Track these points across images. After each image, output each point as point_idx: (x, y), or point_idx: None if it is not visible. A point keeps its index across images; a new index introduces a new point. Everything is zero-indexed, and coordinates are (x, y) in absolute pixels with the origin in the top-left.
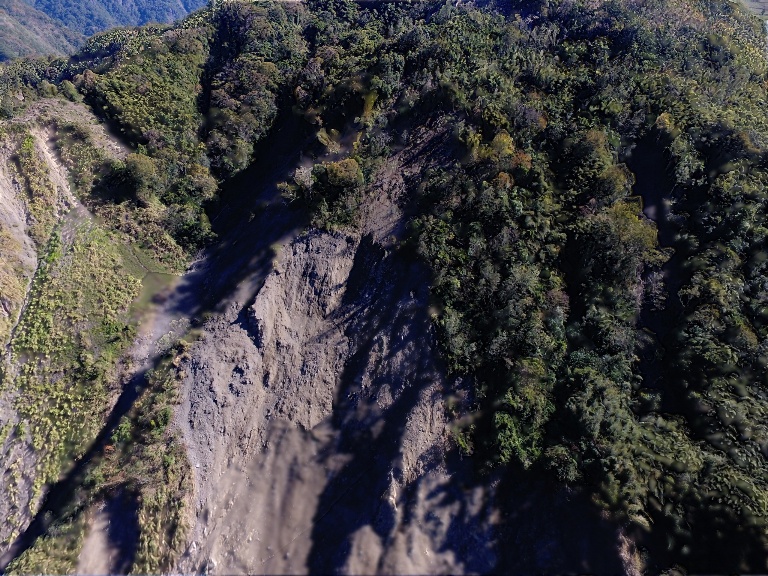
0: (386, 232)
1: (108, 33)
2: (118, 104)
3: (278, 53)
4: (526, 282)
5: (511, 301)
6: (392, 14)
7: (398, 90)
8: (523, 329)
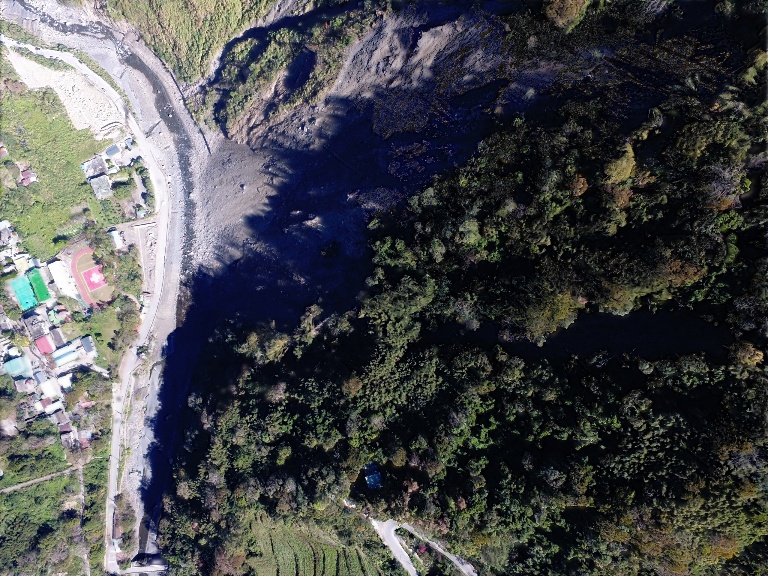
0: (513, 96)
1: None
2: None
3: None
4: None
5: (449, 227)
6: None
7: None
8: None
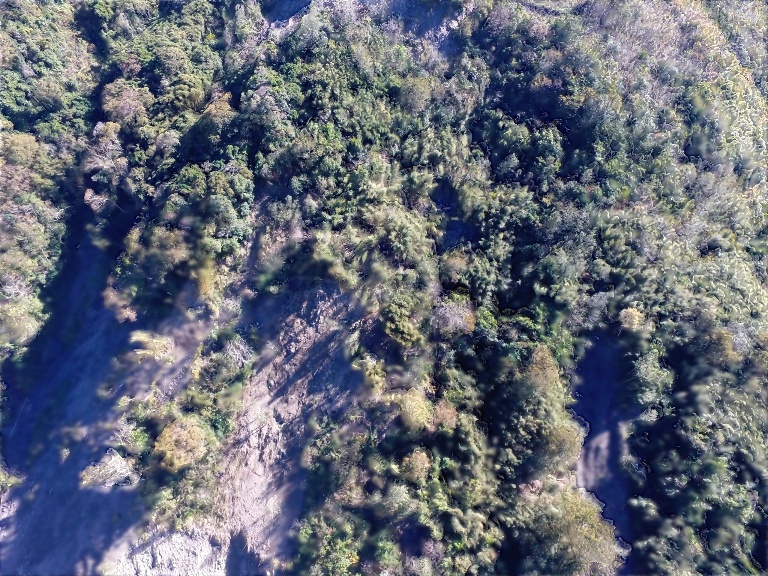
0: (264, 531)
1: None
2: None
3: None
4: None
5: None
6: None
7: (251, 232)
8: None
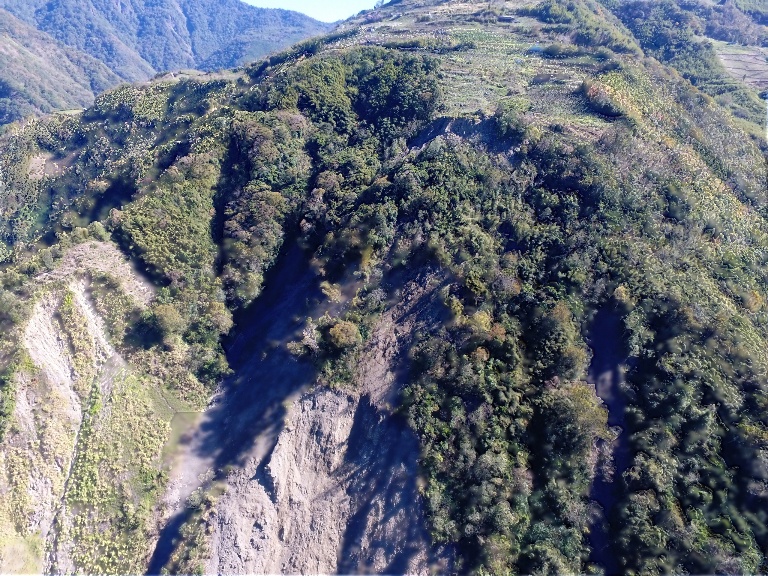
0: (381, 394)
1: (116, 91)
2: (142, 244)
3: (283, 176)
4: (497, 463)
5: (484, 483)
6: (387, 131)
7: (392, 239)
8: (493, 511)
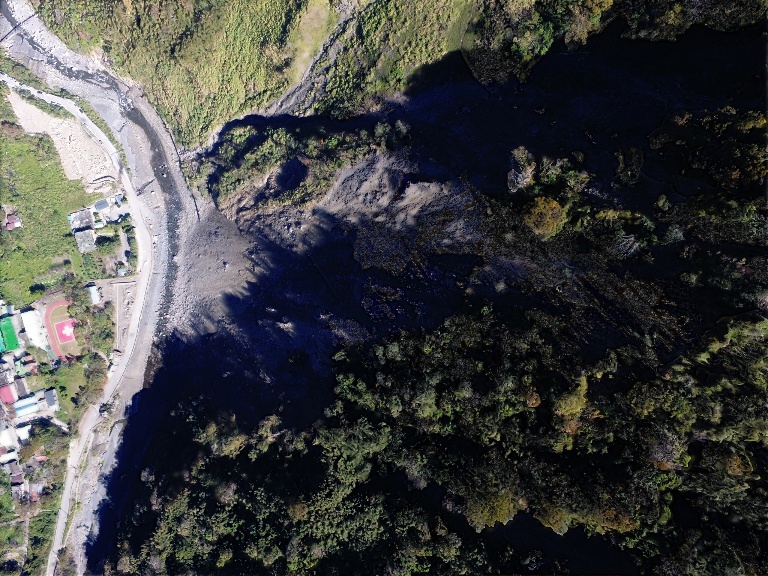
0: (486, 279)
1: None
2: None
3: None
4: None
5: (407, 390)
6: None
7: None
8: None
